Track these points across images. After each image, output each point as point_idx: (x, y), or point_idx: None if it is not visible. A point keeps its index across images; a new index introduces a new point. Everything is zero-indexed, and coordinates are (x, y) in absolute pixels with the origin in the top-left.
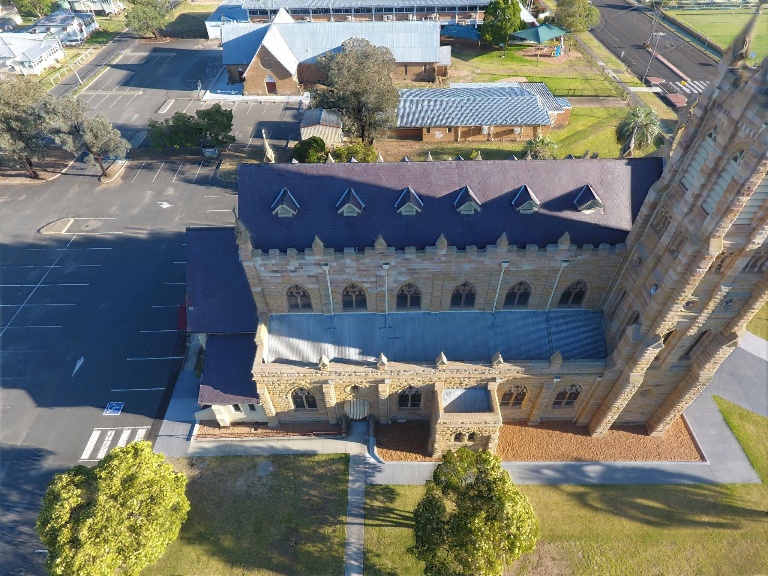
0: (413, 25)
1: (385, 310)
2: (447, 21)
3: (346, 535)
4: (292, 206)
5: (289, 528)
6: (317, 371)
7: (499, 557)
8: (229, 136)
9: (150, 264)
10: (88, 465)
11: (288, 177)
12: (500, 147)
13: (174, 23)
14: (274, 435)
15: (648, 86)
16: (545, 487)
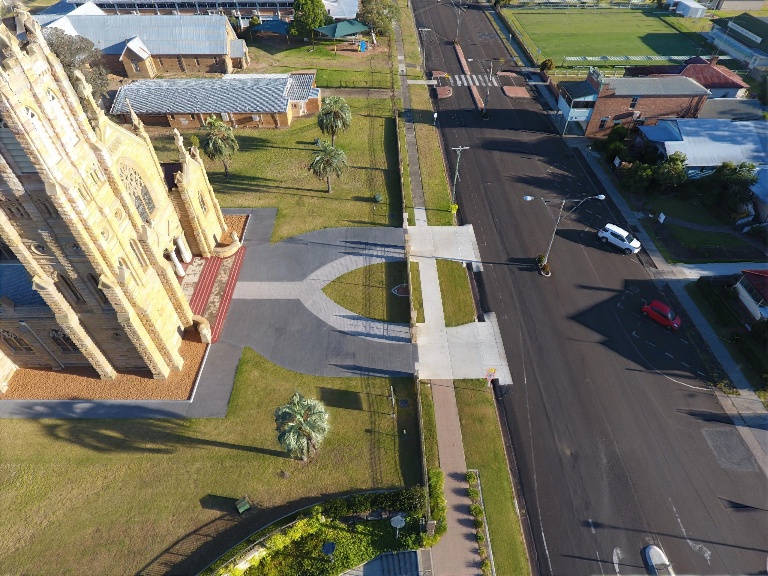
0: (200, 19)
1: None
2: (271, 17)
3: None
4: None
5: None
6: None
7: None
8: None
9: None
10: None
11: None
12: (238, 133)
13: None
14: None
15: (428, 79)
16: (26, 420)
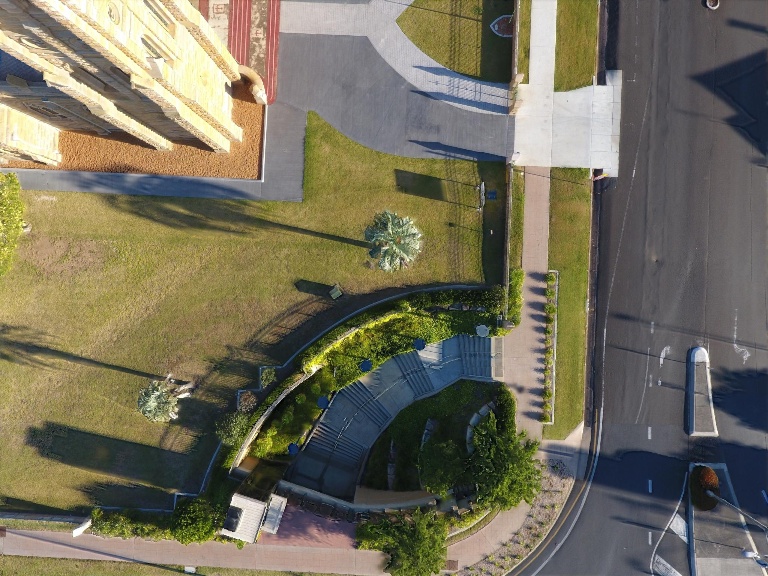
0: None
1: None
2: None
3: None
4: None
5: None
6: None
7: None
8: None
9: None
10: None
11: None
12: None
13: None
14: None
15: None
16: (100, 195)
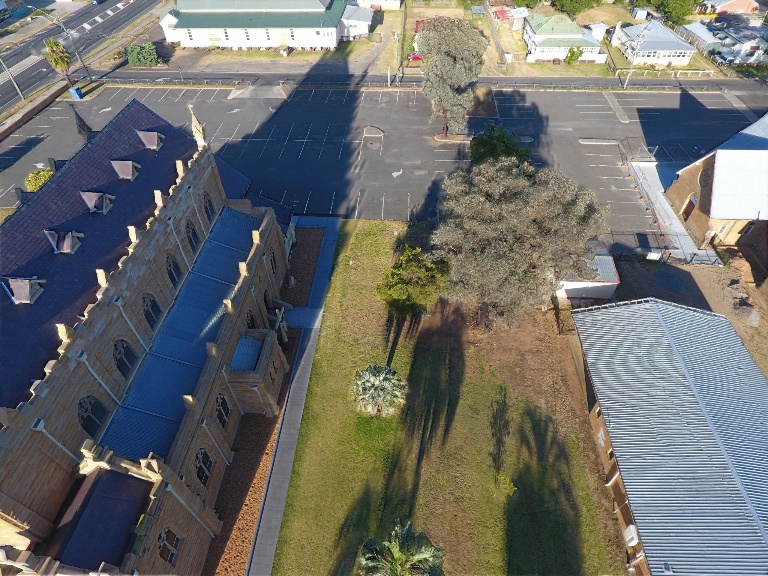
0: None
1: None
2: None
3: None
4: None
5: None
6: None
7: None
8: None
9: (312, 180)
10: None
11: None
12: None
13: None
14: None
15: None
16: None
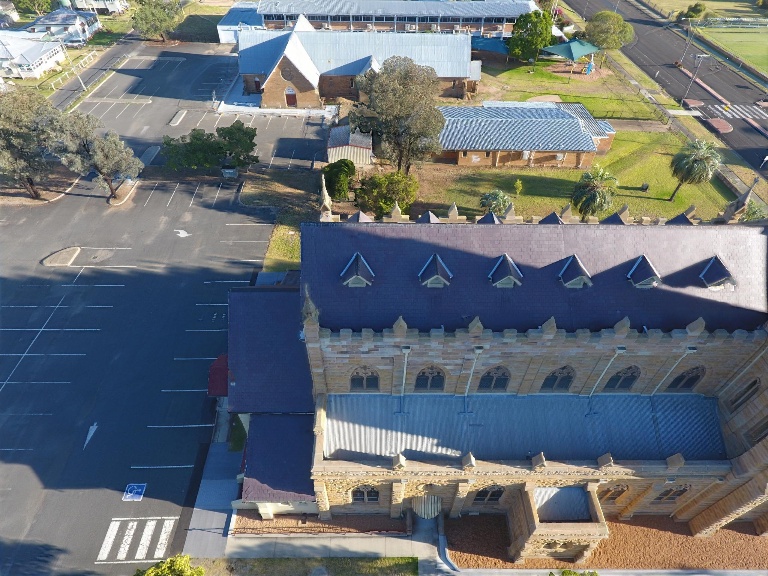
0: (443, 38)
1: (465, 392)
2: (472, 32)
3: None
4: (367, 276)
5: None
6: (390, 471)
7: None
8: (252, 156)
9: (169, 306)
10: (106, 569)
11: (361, 239)
12: (542, 174)
13: (182, 25)
14: (326, 531)
15: (687, 109)
16: None
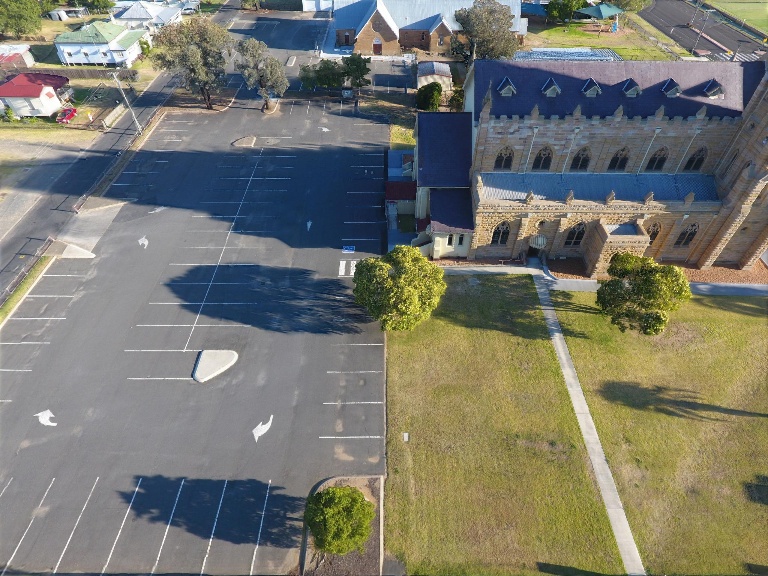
0: None
1: (562, 171)
2: None
3: (544, 315)
4: (514, 88)
5: (503, 311)
6: (524, 204)
7: (670, 300)
8: (366, 80)
9: (332, 167)
10: (346, 278)
11: (509, 69)
12: None
13: None
14: (473, 265)
15: (697, 56)
16: None
